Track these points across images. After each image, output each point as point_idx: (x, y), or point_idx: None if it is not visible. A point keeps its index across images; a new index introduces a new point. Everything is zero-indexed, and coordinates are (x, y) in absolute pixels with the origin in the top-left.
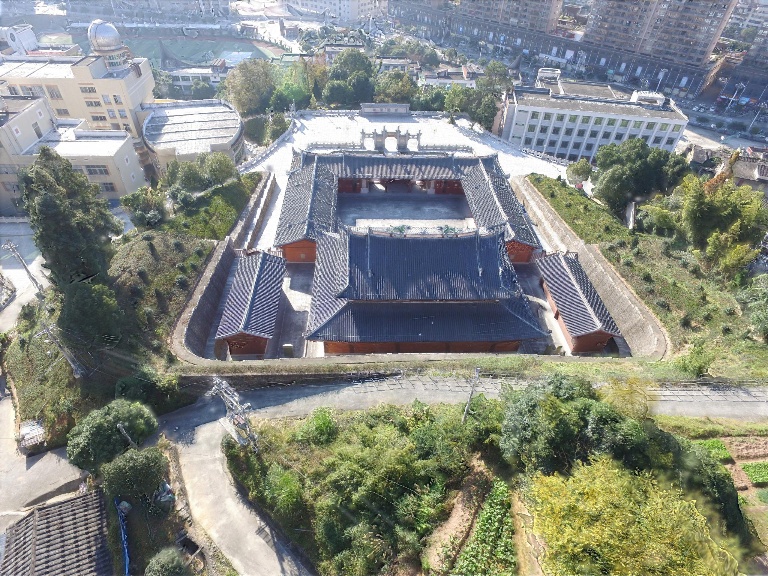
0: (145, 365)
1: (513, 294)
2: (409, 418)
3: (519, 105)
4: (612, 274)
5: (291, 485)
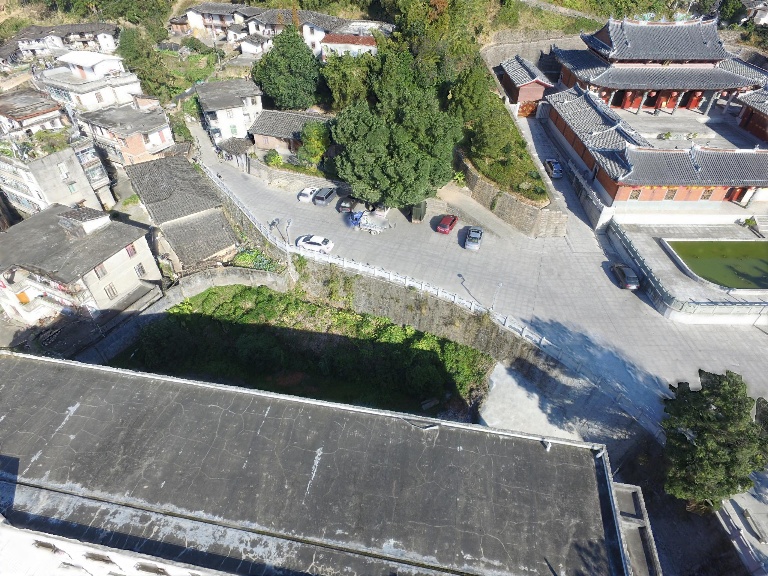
0: (750, 18)
1: (584, 35)
2: (624, 3)
3: (596, 444)
4: (494, 76)
5: (655, 1)
